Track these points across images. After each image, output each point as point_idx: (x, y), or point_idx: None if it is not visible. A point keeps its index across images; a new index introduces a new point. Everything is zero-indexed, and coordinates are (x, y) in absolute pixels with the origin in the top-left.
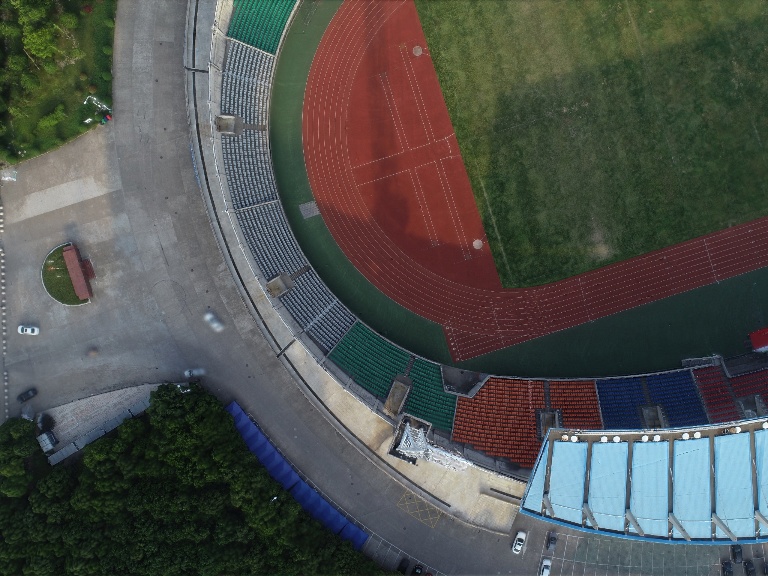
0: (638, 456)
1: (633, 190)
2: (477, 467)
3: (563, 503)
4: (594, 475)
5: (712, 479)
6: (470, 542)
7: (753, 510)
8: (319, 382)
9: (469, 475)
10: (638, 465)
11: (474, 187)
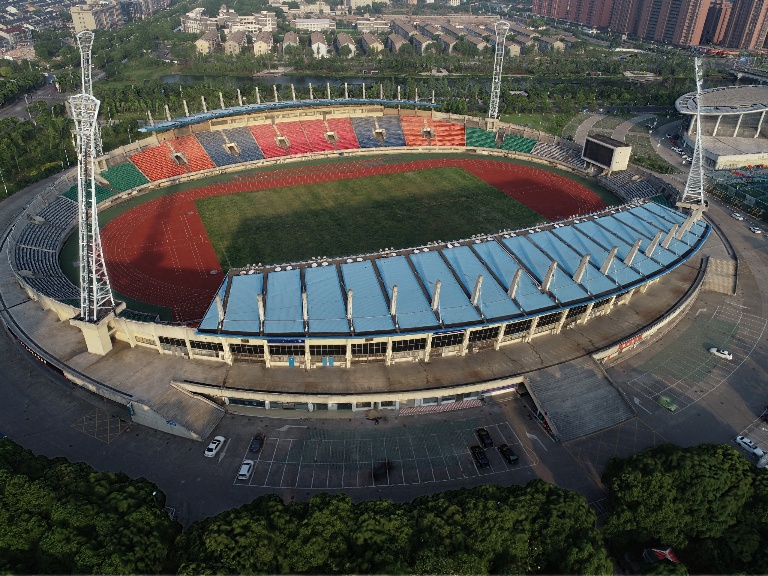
0: (310, 277)
1: (337, 249)
2: (162, 325)
3: (240, 319)
4: (270, 294)
5: (382, 286)
6: (152, 453)
7: (429, 305)
8: (31, 323)
9: (162, 372)
10: (311, 282)
11: (217, 251)
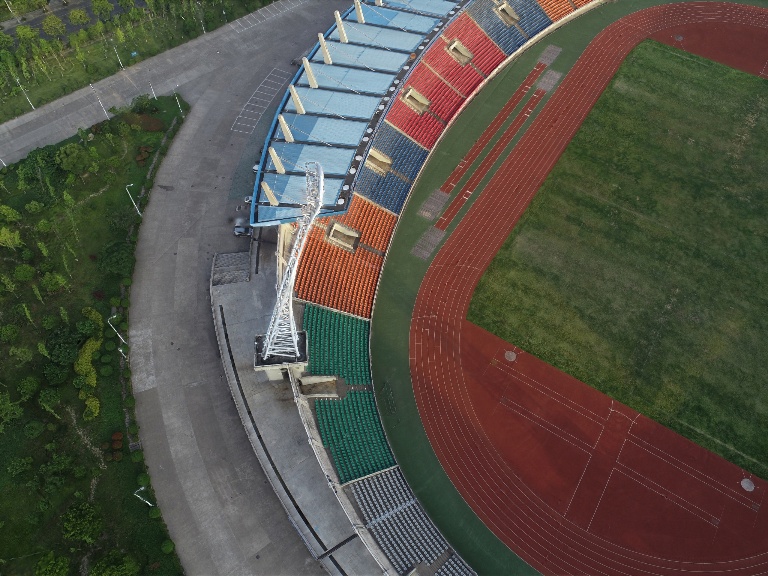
0: None
1: None
2: None
3: None
4: None
5: None
6: None
7: None
8: None
9: None
10: None
11: (682, 432)
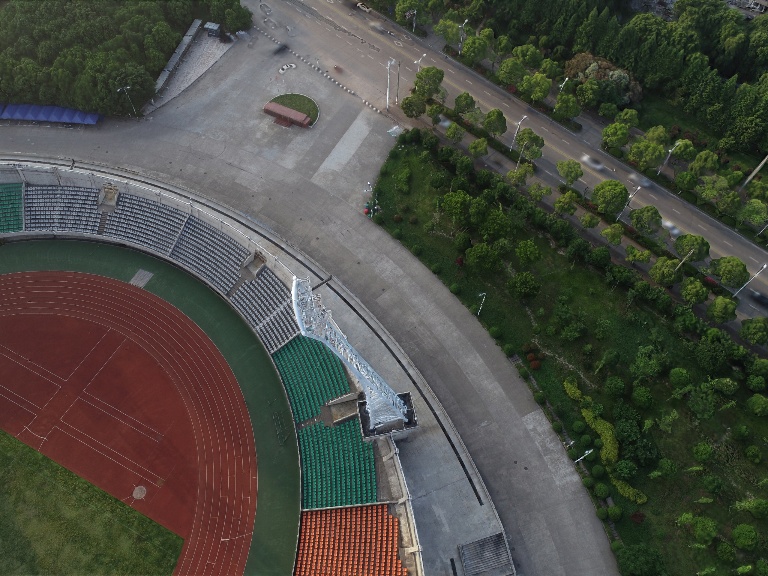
0: None
1: None
2: None
3: None
4: None
5: None
6: None
7: None
8: None
9: None
10: None
11: None
